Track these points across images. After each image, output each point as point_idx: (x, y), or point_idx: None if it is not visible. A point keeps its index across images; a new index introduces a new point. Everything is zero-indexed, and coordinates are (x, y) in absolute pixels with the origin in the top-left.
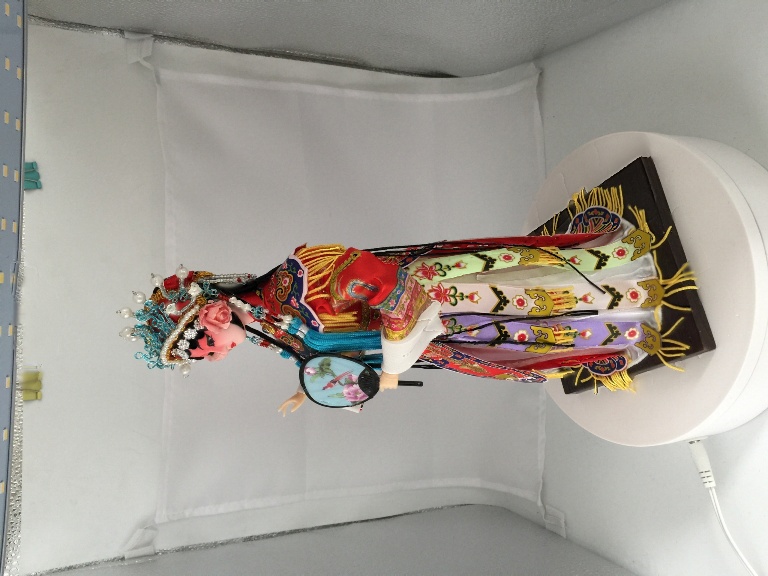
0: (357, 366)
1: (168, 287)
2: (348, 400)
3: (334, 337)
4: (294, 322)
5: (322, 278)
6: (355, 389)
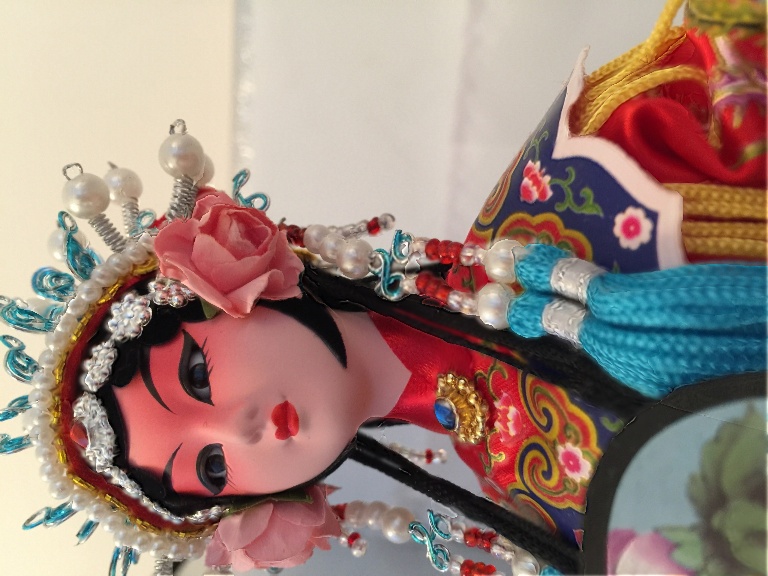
0: None
1: (157, 228)
2: None
3: (763, 281)
4: (528, 250)
5: (652, 60)
6: None
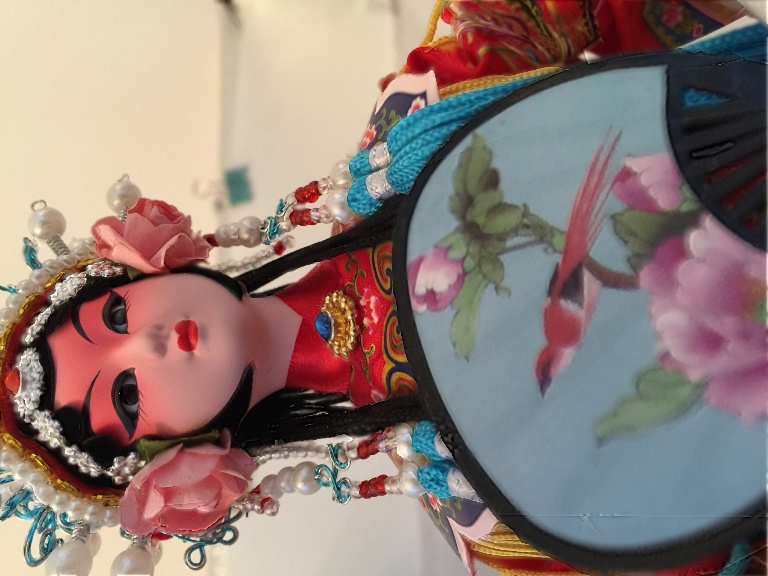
0: (619, 91)
1: None
2: (750, 420)
3: None
4: None
5: None
6: (723, 273)
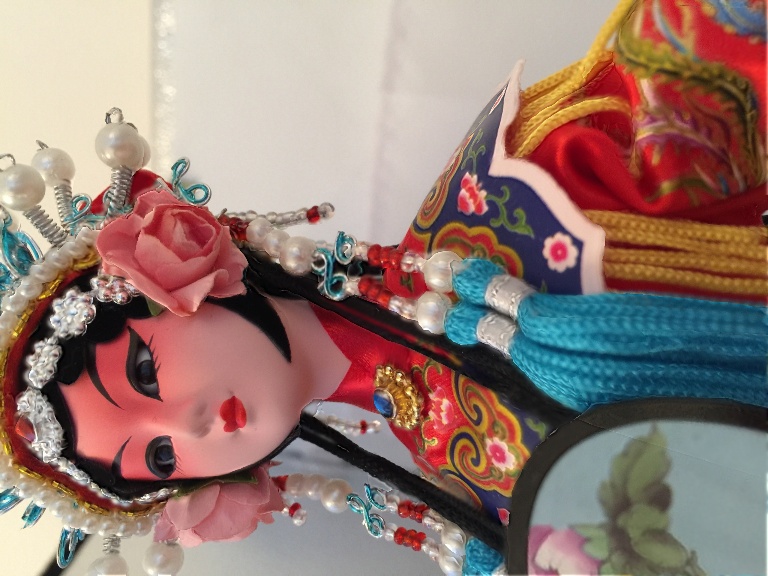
0: None
1: (92, 210)
2: None
3: (669, 311)
4: (465, 265)
5: (583, 80)
6: None
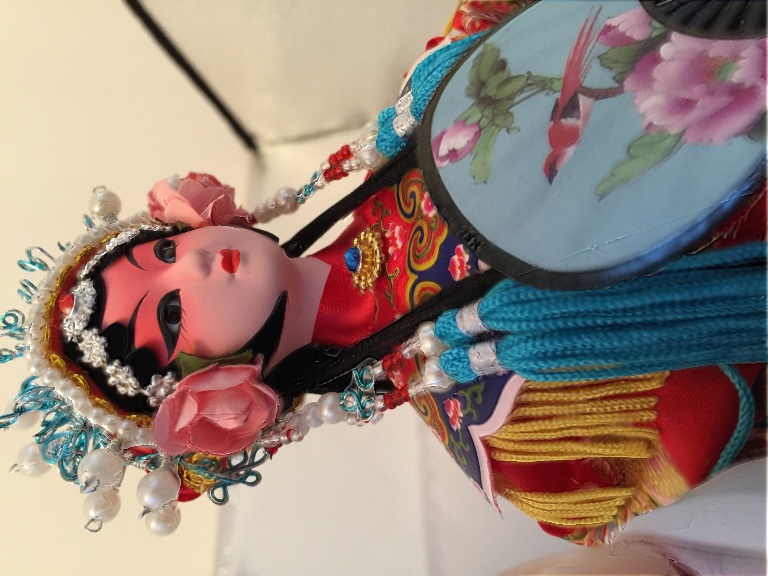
0: None
1: None
2: (720, 143)
3: None
4: None
5: None
6: (688, 63)
